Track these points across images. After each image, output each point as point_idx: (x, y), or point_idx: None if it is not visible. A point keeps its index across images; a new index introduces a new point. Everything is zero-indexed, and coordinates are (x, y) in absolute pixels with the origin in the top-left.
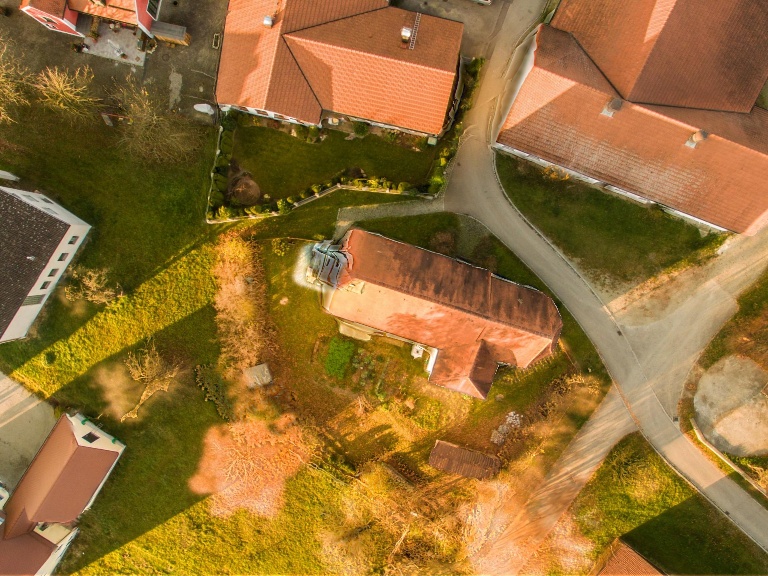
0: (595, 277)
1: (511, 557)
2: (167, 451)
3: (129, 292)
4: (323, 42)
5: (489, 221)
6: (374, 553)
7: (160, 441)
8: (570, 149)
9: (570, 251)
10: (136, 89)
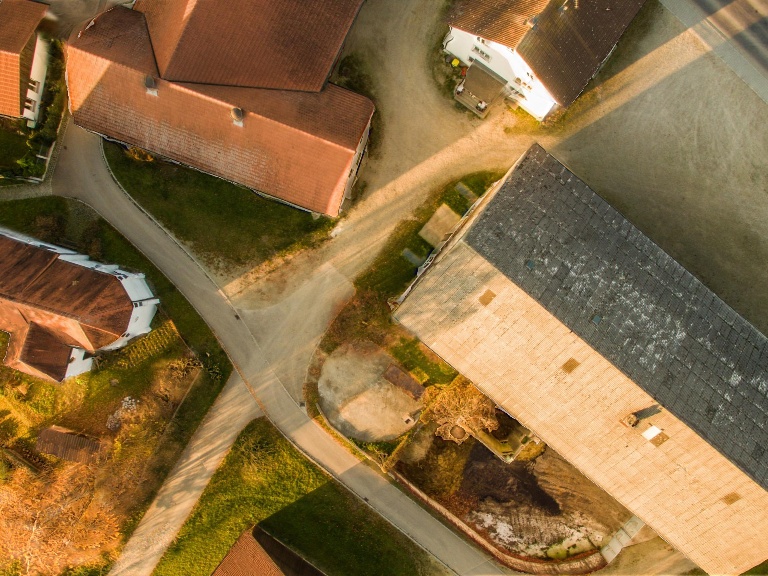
0: (209, 261)
1: (151, 544)
2: None
3: None
4: None
5: (99, 205)
6: (12, 540)
7: None
8: (139, 130)
9: (182, 234)
10: None
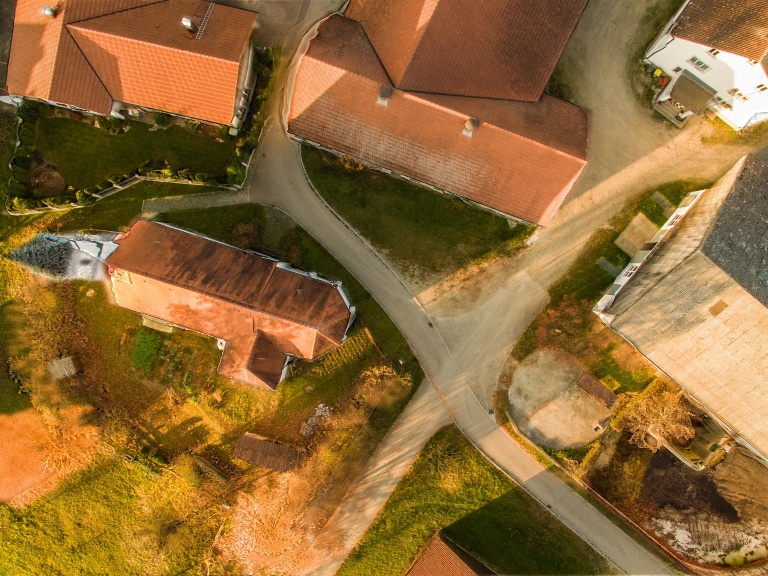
0: (404, 268)
1: (333, 551)
2: None
3: None
4: (106, 32)
5: (295, 212)
6: (194, 546)
7: None
8: (357, 139)
9: (378, 242)
10: None
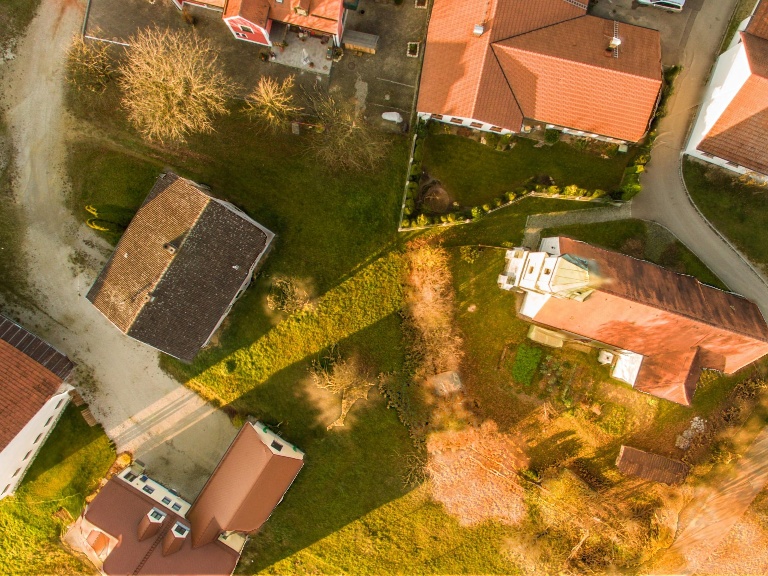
0: None
1: (685, 561)
2: (346, 458)
3: (314, 300)
4: (531, 51)
5: (675, 227)
6: (550, 558)
7: (339, 448)
8: None
9: (754, 257)
10: (324, 97)
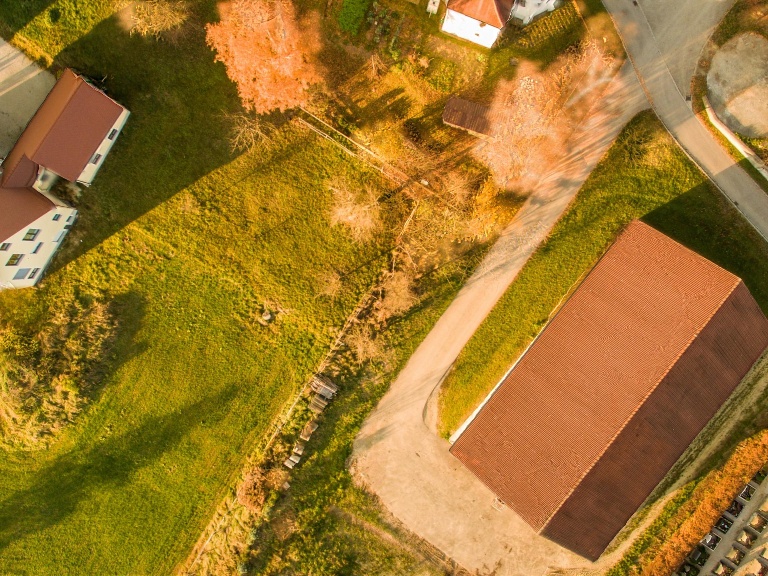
0: None
1: (520, 244)
2: (173, 118)
3: None
4: None
5: None
6: (382, 234)
7: (166, 108)
8: None
9: None
10: None
